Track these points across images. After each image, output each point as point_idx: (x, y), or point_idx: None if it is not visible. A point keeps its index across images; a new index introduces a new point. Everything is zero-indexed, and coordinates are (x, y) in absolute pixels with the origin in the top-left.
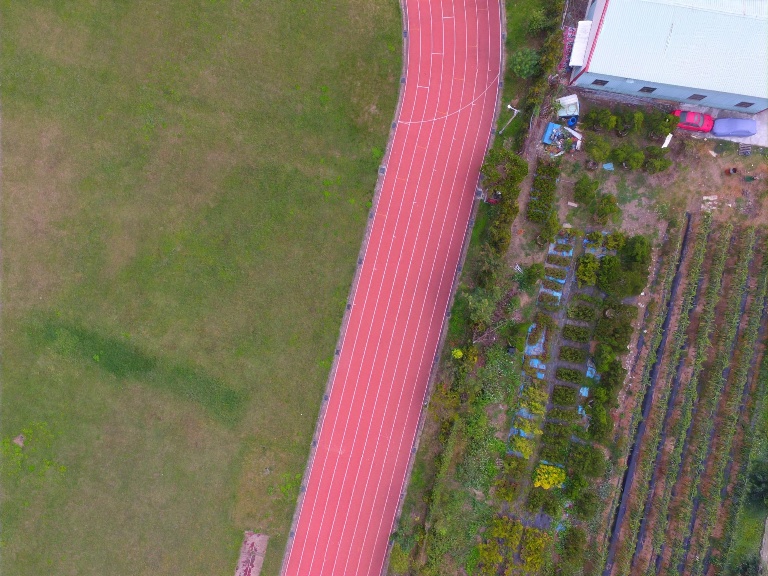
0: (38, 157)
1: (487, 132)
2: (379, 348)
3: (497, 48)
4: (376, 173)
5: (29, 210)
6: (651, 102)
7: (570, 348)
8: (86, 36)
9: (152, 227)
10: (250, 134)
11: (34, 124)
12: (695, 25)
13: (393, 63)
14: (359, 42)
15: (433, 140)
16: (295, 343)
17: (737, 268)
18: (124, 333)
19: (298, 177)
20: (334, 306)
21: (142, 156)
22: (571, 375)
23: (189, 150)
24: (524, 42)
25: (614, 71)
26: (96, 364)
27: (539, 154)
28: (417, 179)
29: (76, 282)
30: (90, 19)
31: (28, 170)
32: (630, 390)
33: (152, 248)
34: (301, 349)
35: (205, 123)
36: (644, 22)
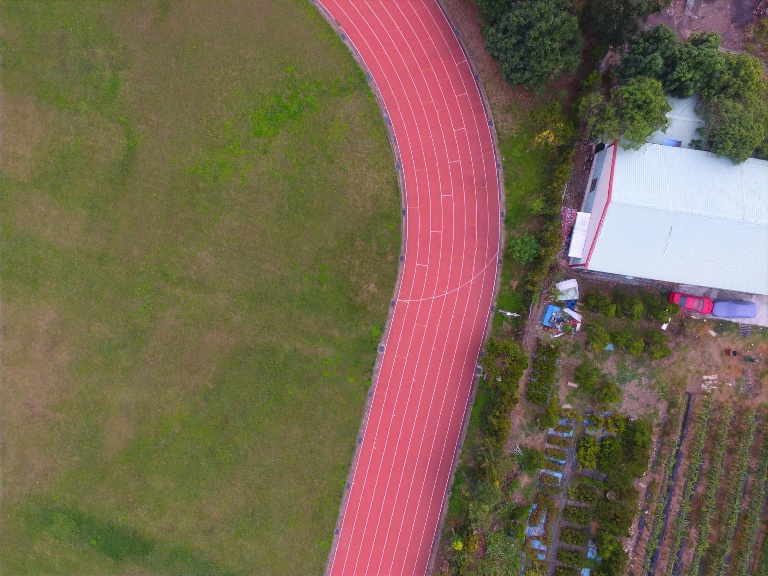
0: (35, 341)
1: (486, 309)
2: (379, 527)
3: (496, 226)
4: (375, 352)
5: (26, 394)
6: (650, 283)
7: (571, 531)
8: (83, 219)
9: (150, 409)
10: (248, 314)
11: (31, 307)
12: (694, 229)
13: (392, 242)
14: (358, 221)
15: (432, 318)
16: (294, 524)
17: (738, 450)
18: (122, 516)
19: (297, 357)
20: (333, 486)
21: (140, 338)
22: (572, 559)
23: (187, 331)
24: (523, 220)
25: (613, 269)
26: (93, 548)
27: (539, 335)
28: (416, 357)
29: (73, 466)
30: (87, 202)
31: (25, 354)
32: (632, 571)
33: (150, 430)
34: (300, 530)
35: (203, 304)
36: (643, 227)
